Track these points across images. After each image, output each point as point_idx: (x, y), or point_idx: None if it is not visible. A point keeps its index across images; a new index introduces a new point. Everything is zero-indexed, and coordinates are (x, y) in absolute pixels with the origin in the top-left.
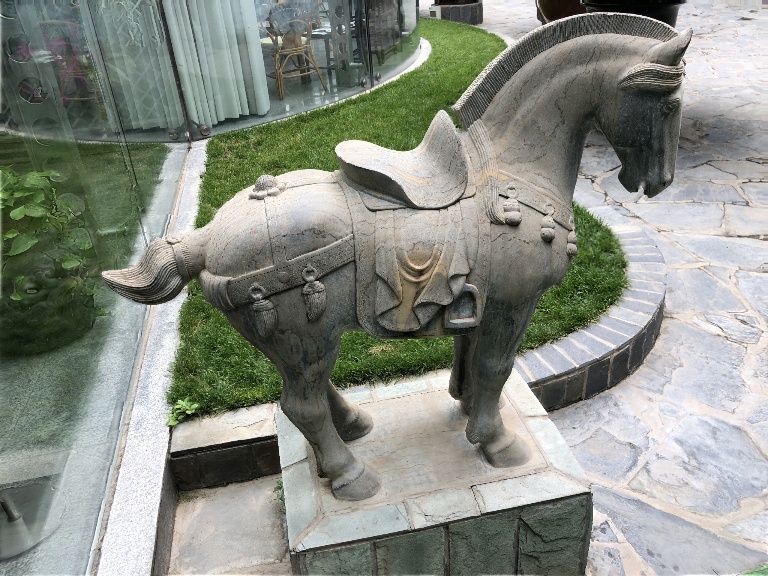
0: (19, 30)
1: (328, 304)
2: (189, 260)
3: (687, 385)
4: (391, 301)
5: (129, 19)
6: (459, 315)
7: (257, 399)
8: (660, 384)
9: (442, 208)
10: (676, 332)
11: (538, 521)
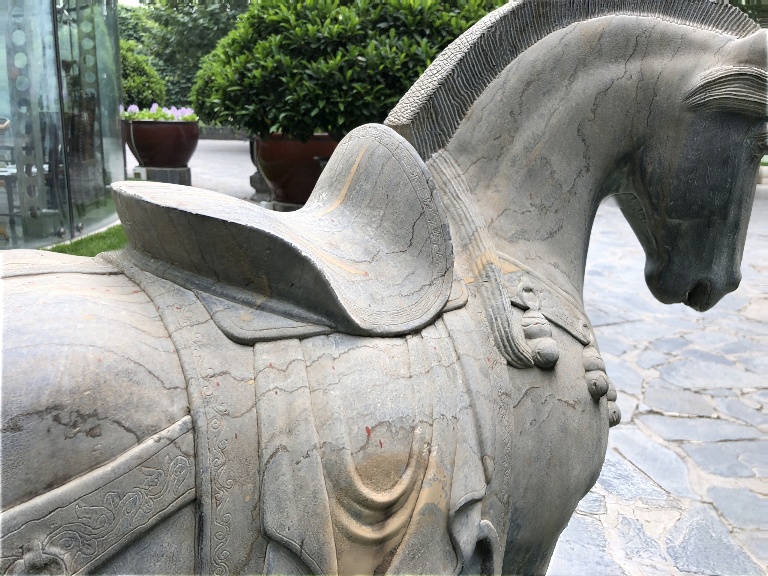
0: None
1: None
2: None
3: None
4: None
5: None
6: None
7: None
8: None
9: (410, 332)
10: None
11: None
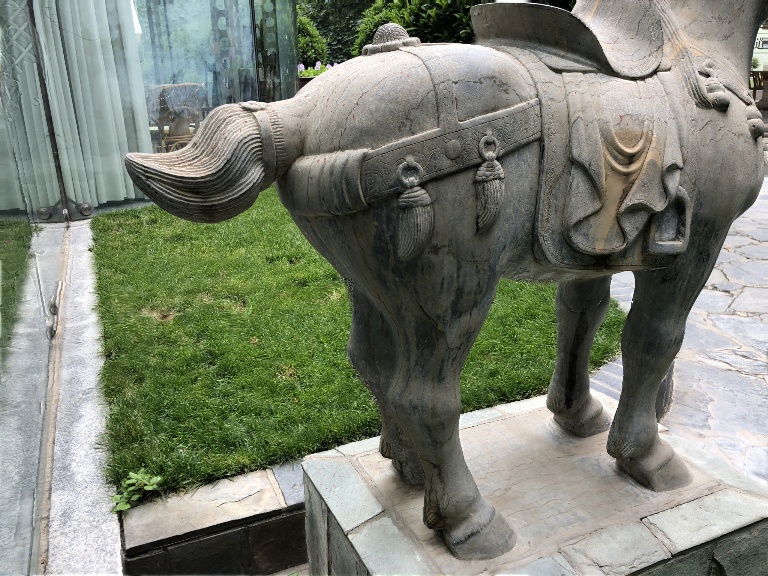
0: None
1: (504, 205)
2: (281, 137)
3: (730, 418)
4: (590, 203)
5: (7, 76)
6: (661, 236)
7: (244, 465)
8: (703, 419)
9: (638, 79)
10: (687, 369)
11: (734, 560)
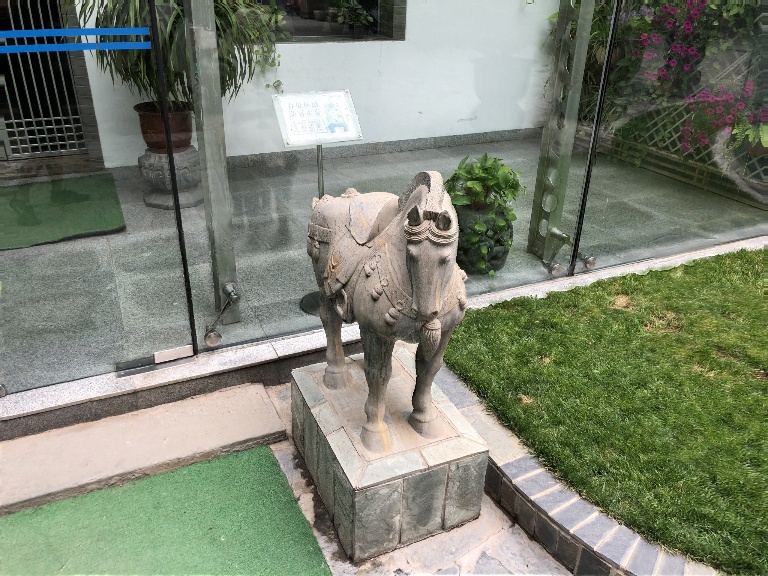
0: (568, 81)
1: (320, 257)
2: None
3: None
4: None
5: None
6: None
7: None
8: None
9: (358, 244)
10: None
11: None
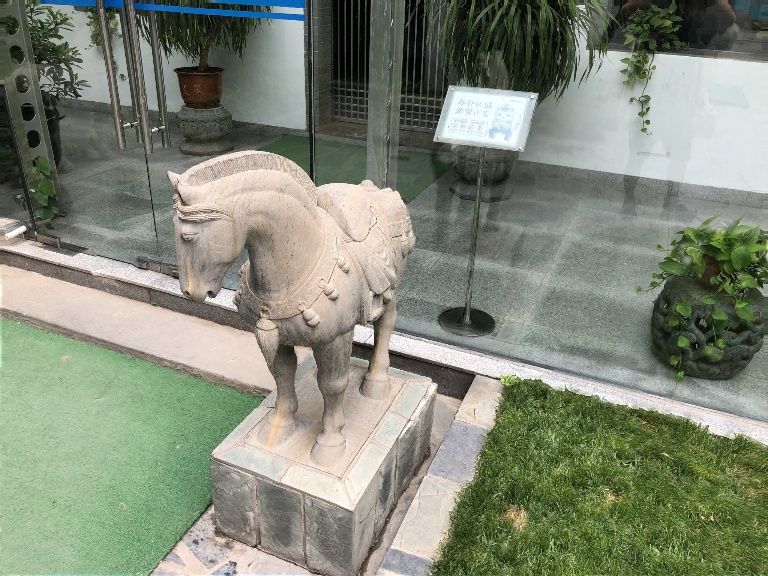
0: None
1: None
2: None
3: None
4: None
5: None
6: None
7: None
8: None
9: None
10: None
11: None
